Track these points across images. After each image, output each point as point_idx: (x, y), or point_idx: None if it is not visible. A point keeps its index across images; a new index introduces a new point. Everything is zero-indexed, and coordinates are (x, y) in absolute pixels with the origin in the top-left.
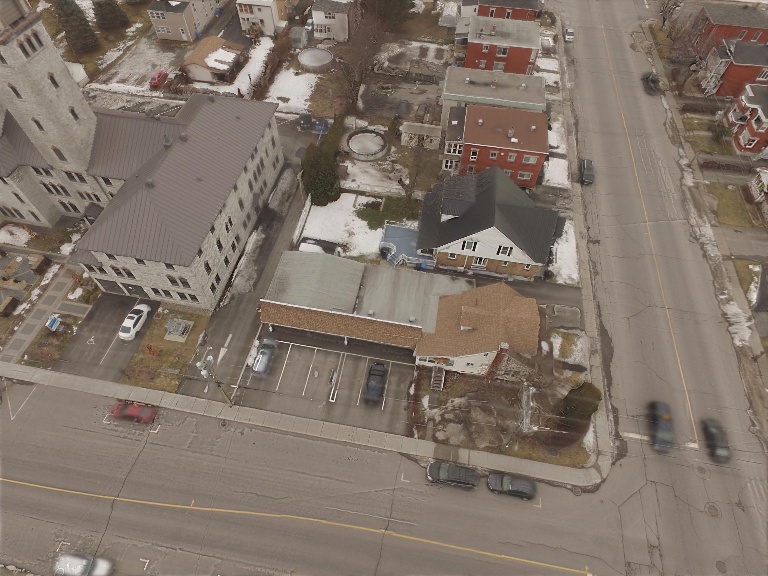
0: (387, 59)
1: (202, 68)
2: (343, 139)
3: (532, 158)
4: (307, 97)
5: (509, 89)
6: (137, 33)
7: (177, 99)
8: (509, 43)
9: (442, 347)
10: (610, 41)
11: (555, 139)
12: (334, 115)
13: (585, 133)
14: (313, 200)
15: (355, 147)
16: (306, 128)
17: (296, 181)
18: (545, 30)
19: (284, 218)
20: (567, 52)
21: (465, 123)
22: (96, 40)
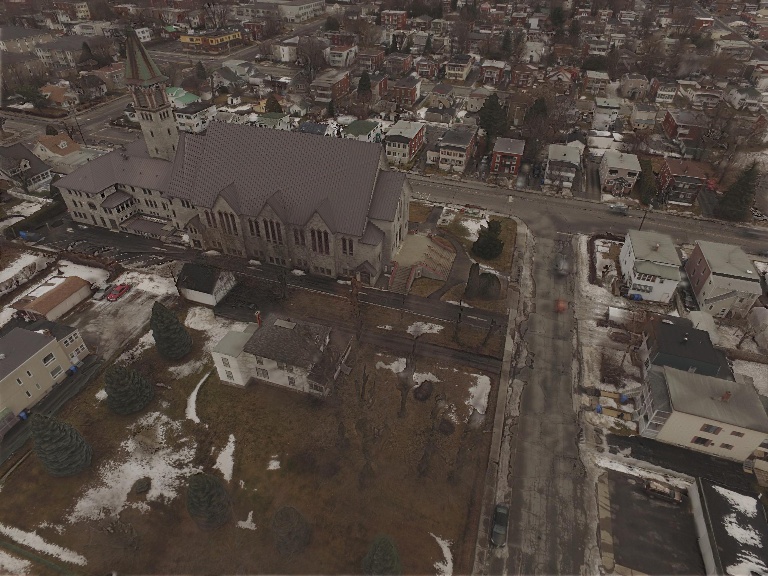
0: None
1: None
2: None
3: None
4: (7, 269)
5: None
6: None
7: None
8: None
9: (79, 147)
10: None
11: None
12: (12, 228)
13: None
14: None
15: None
16: None
17: None
18: None
19: None
20: None
21: None
22: None
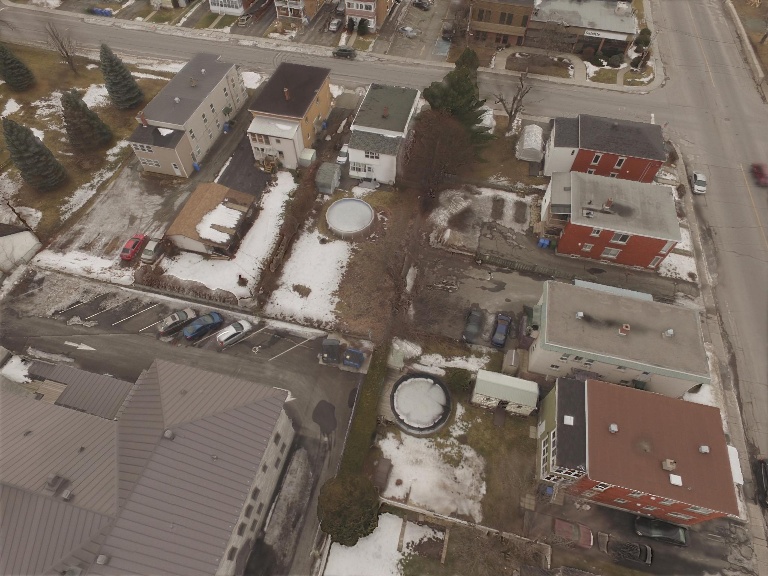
0: (448, 220)
1: (192, 240)
2: (385, 394)
3: (704, 509)
4: (335, 287)
5: (646, 336)
6: (120, 157)
7: (153, 292)
8: (633, 230)
9: None
10: (757, 195)
11: (738, 465)
12: (373, 350)
13: (750, 385)
14: (335, 540)
15: (402, 408)
16: (331, 361)
17: (310, 479)
18: (663, 172)
19: (287, 571)
20: (698, 213)
21: (587, 427)
22: (62, 175)
